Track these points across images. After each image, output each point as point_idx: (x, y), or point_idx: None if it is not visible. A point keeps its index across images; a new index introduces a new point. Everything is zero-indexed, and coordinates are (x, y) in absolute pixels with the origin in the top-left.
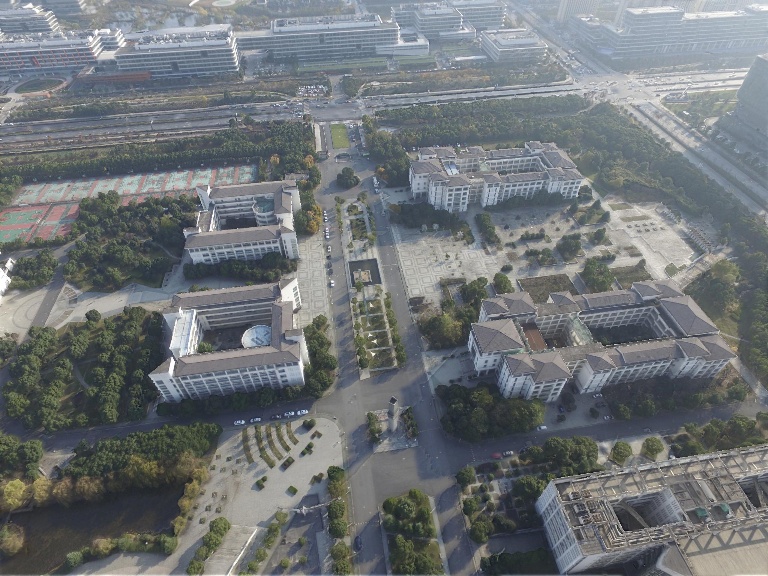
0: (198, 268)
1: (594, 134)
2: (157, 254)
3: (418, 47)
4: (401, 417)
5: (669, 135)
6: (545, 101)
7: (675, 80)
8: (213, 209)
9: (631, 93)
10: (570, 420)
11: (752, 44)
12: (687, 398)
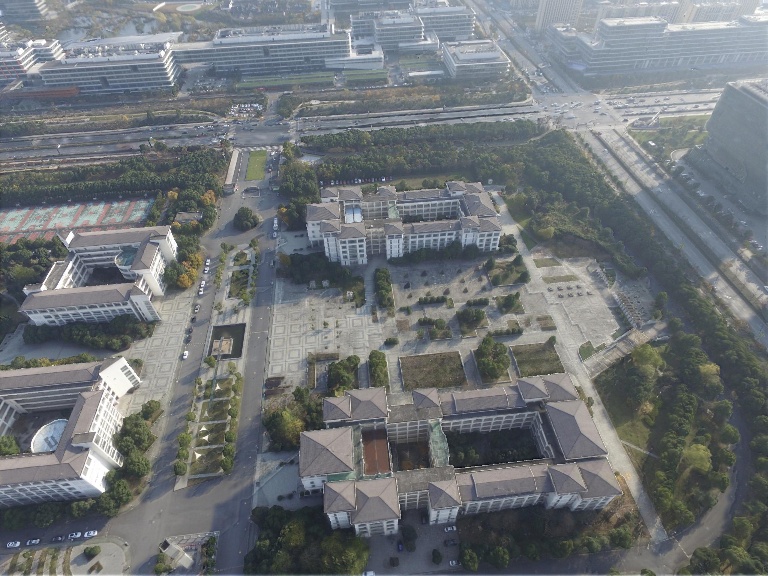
0: (36, 332)
1: (536, 170)
2: (7, 309)
3: (371, 60)
4: (202, 548)
5: (626, 171)
6: (491, 127)
7: (650, 102)
8: (71, 260)
9: (595, 117)
10: (407, 563)
11: (748, 58)
12: (554, 545)
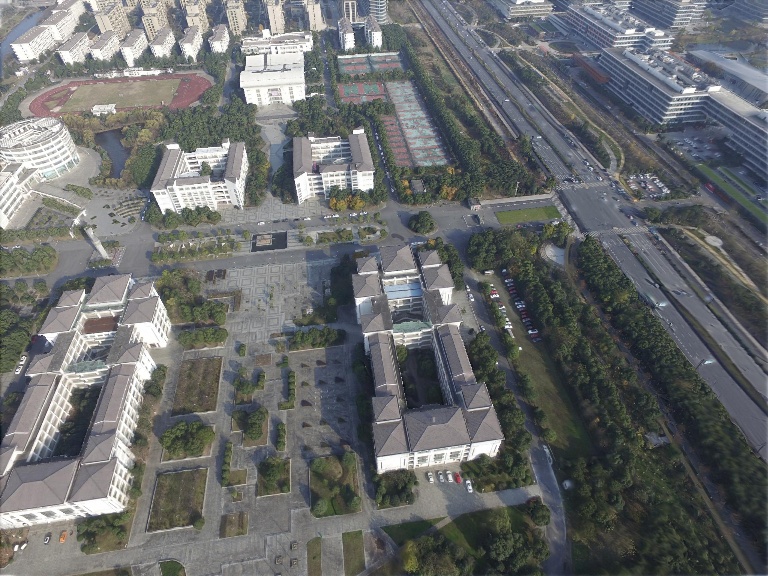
0: None
1: None
2: None
3: None
4: None
5: None
6: (757, 496)
7: None
8: None
9: None
10: None
11: None
12: None
